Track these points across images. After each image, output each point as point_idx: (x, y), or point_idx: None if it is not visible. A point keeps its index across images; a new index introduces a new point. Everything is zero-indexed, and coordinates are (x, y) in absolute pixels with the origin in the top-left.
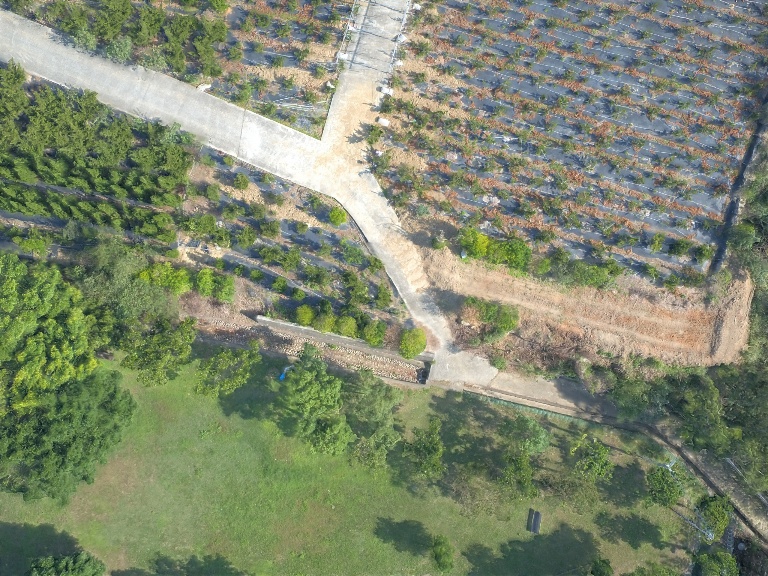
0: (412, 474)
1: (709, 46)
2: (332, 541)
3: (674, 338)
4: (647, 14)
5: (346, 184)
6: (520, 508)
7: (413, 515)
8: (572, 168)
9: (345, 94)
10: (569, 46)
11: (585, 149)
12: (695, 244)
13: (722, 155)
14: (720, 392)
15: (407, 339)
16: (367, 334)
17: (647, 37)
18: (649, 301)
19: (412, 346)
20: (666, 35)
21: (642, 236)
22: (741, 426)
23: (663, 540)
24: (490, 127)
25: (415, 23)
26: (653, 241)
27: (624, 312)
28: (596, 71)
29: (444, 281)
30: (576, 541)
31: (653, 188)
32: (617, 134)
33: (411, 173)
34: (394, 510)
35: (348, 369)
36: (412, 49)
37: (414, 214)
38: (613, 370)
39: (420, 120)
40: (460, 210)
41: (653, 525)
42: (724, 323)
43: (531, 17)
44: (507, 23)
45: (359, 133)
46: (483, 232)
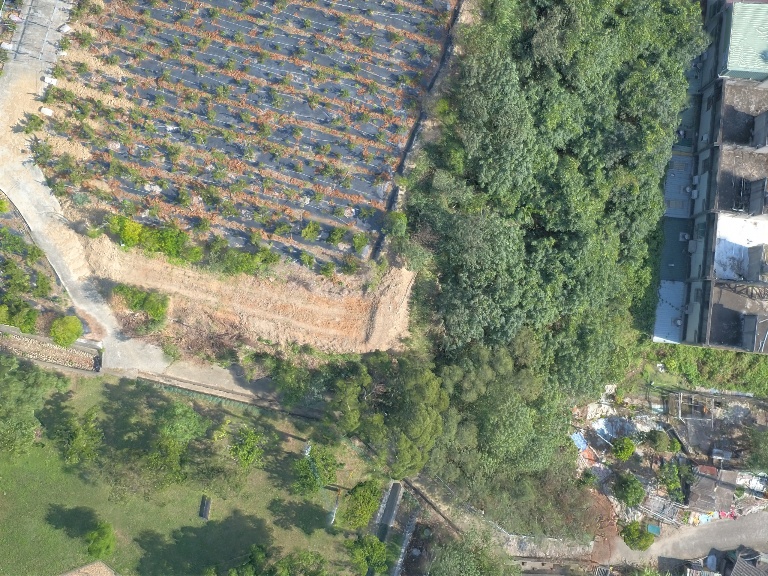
0: (84, 461)
1: (372, 34)
2: (4, 527)
3: (330, 325)
4: (311, 3)
5: (10, 173)
6: (193, 494)
7: (85, 501)
8: (233, 156)
9: (9, 84)
10: (232, 35)
11: (248, 137)
12: (356, 231)
13: (383, 143)
14: (374, 378)
15: (56, 326)
16: (15, 322)
17: (308, 25)
18: (306, 288)
19: (62, 333)
20: (329, 23)
21: (302, 224)
22: (397, 412)
23: (336, 525)
24: (154, 116)
25: (77, 13)
26: (304, 228)
27: (281, 299)
28: (259, 60)
29: (103, 269)
30: (249, 527)
31: (313, 176)
32: (279, 122)
33: (74, 162)
34: (66, 496)
35: (21, 357)
36: (76, 39)
37: (75, 203)
38: (279, 357)
39: (82, 109)
40: (122, 199)
41: (326, 511)
42: (378, 310)
43: (196, 6)
44: (171, 12)
45: (23, 123)
46: (145, 220)
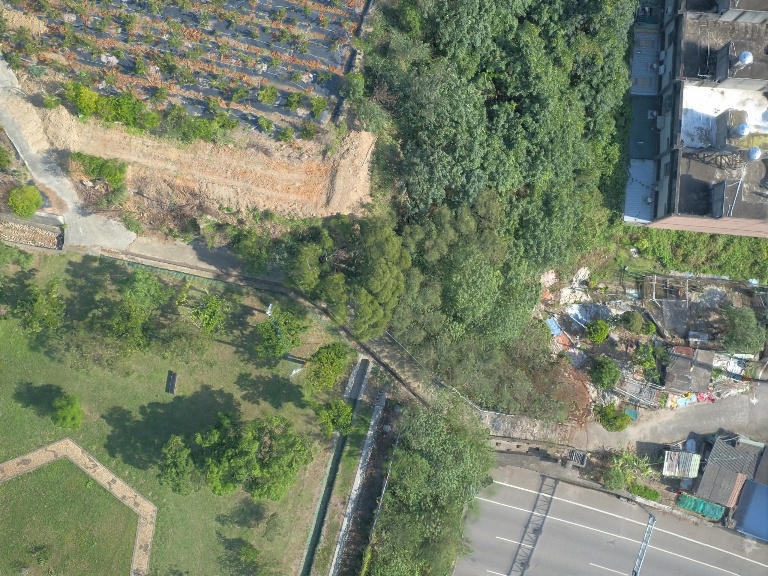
0: (49, 339)
1: None
2: None
3: (290, 190)
4: None
5: None
6: (159, 370)
7: (50, 379)
8: (190, 25)
9: None
10: None
11: (204, 6)
12: None
13: (339, 7)
14: (336, 242)
15: (14, 195)
16: None
17: None
18: (265, 154)
19: (21, 203)
20: None
21: None
22: (360, 276)
23: (304, 399)
24: None
25: None
26: None
27: (240, 165)
28: None
29: (61, 141)
30: (216, 402)
31: (270, 42)
32: None
33: (30, 36)
34: (31, 375)
35: None
36: None
37: (32, 76)
38: (241, 227)
39: None
40: (80, 71)
41: (293, 384)
42: (338, 172)
43: None
44: None
45: None
46: (102, 92)
